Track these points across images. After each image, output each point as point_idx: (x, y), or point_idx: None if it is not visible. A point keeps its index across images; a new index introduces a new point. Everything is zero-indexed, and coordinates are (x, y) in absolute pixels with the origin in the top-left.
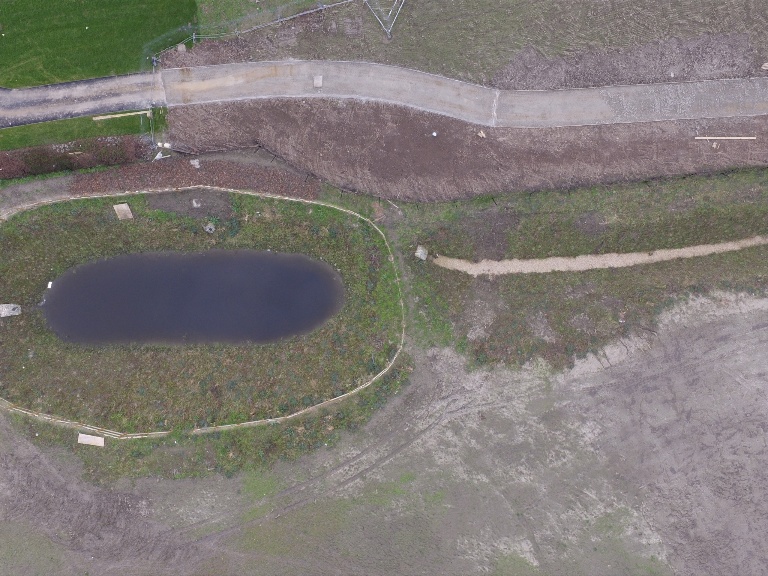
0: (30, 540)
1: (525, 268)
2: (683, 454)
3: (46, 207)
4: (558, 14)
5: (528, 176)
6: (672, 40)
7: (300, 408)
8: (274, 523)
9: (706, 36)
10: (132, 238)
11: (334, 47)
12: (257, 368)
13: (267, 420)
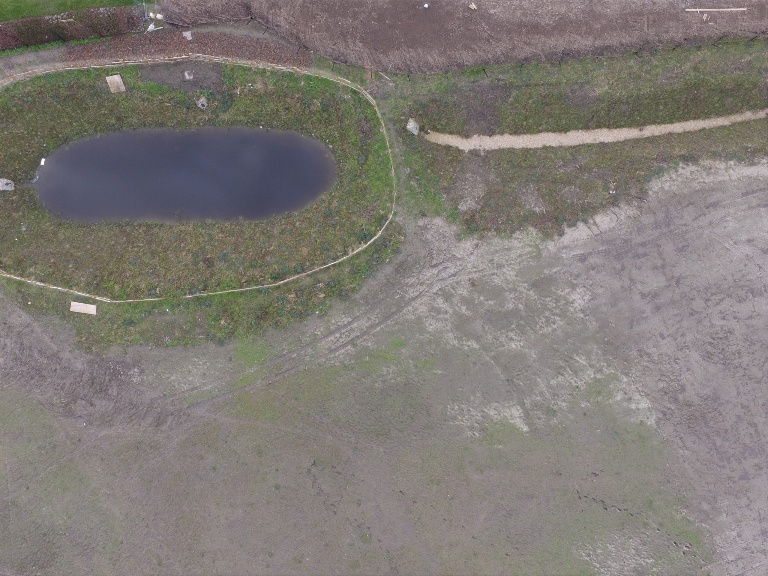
0: (22, 407)
1: (516, 143)
2: (672, 320)
3: (39, 78)
4: None
5: (519, 48)
6: None
7: (291, 276)
8: (265, 390)
9: None
10: (125, 113)
11: None
12: (249, 241)
13: (258, 286)
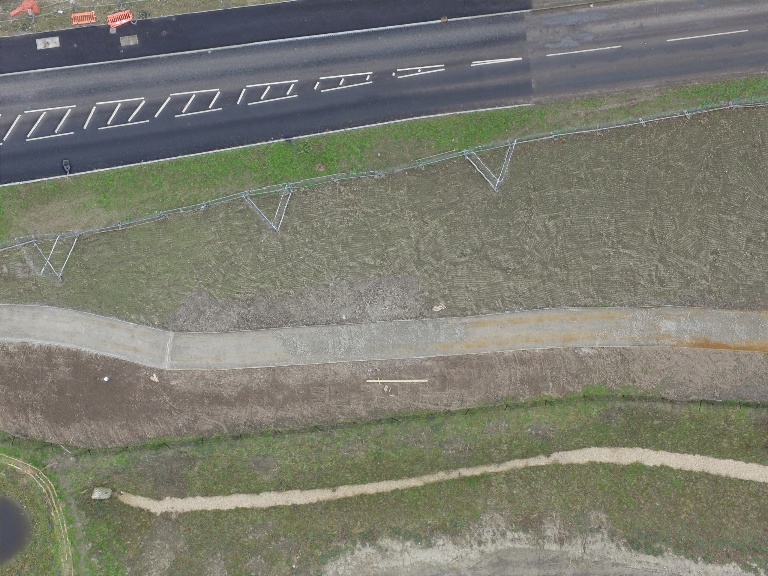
0: None
1: (209, 505)
2: None
3: None
4: (229, 257)
5: (201, 420)
6: (343, 282)
7: None
8: None
9: (377, 278)
10: None
11: (5, 291)
12: None
13: None
